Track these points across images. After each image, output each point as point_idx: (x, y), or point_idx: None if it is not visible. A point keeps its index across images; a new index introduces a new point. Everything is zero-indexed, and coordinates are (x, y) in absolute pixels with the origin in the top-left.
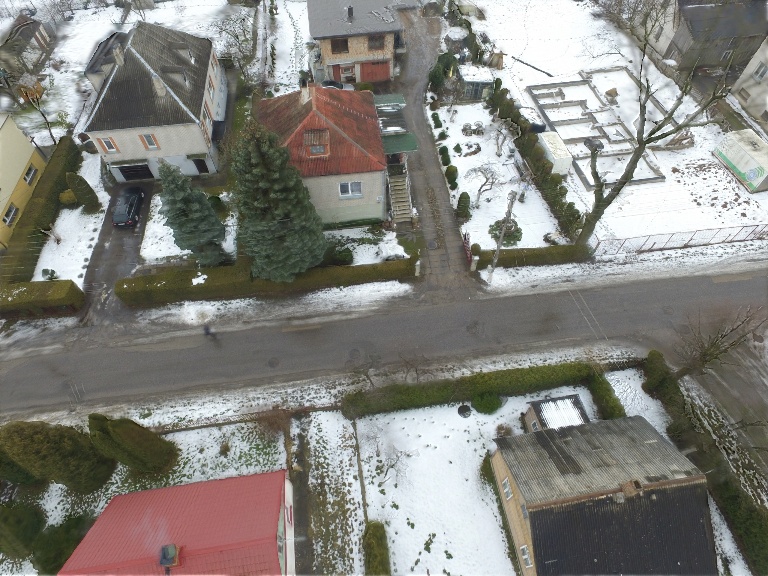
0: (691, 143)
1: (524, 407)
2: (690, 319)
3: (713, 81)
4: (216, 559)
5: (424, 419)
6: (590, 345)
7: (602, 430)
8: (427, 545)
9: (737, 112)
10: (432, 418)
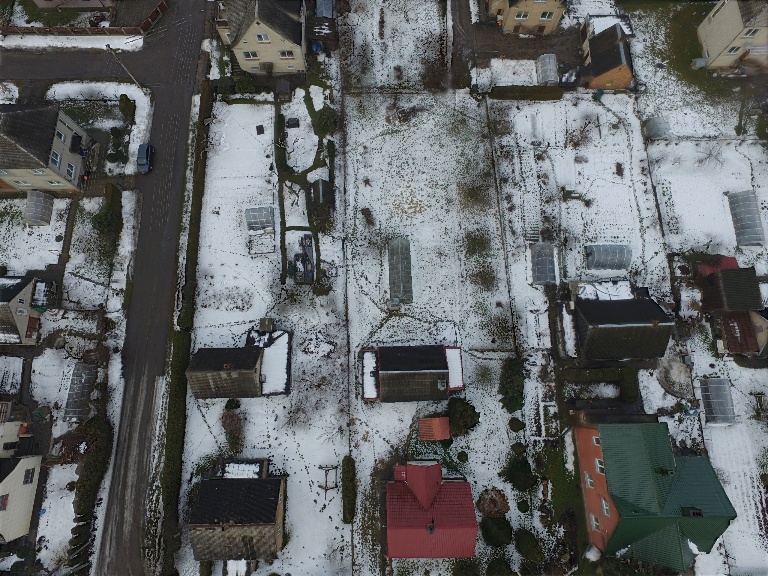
0: None
1: (253, 575)
2: None
3: None
4: (413, 523)
5: (312, 575)
6: None
7: (220, 556)
8: (325, 507)
9: None
10: (308, 575)
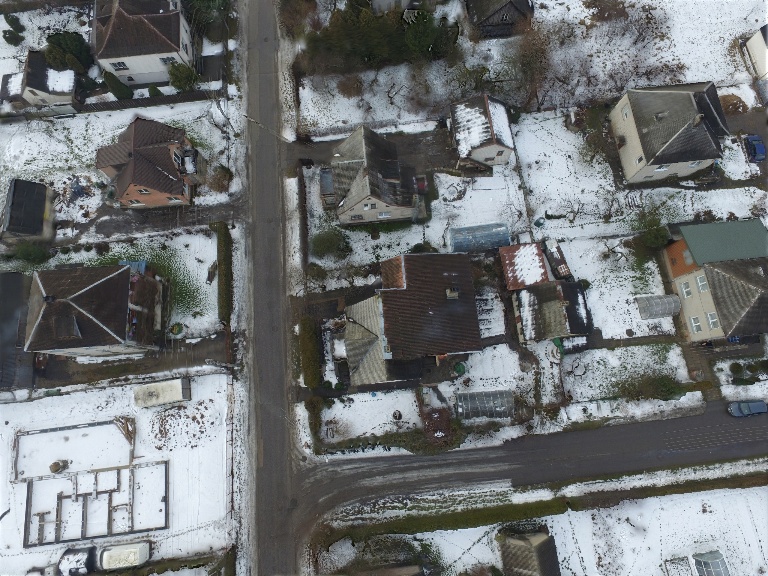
0: (132, 423)
1: None
2: (287, 495)
3: (56, 361)
4: None
5: None
6: (299, 571)
7: None
8: None
9: (101, 362)
10: None
